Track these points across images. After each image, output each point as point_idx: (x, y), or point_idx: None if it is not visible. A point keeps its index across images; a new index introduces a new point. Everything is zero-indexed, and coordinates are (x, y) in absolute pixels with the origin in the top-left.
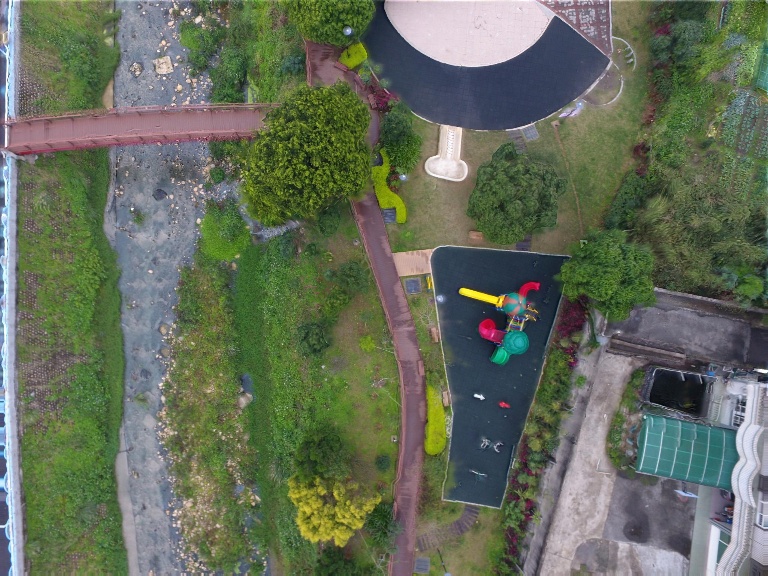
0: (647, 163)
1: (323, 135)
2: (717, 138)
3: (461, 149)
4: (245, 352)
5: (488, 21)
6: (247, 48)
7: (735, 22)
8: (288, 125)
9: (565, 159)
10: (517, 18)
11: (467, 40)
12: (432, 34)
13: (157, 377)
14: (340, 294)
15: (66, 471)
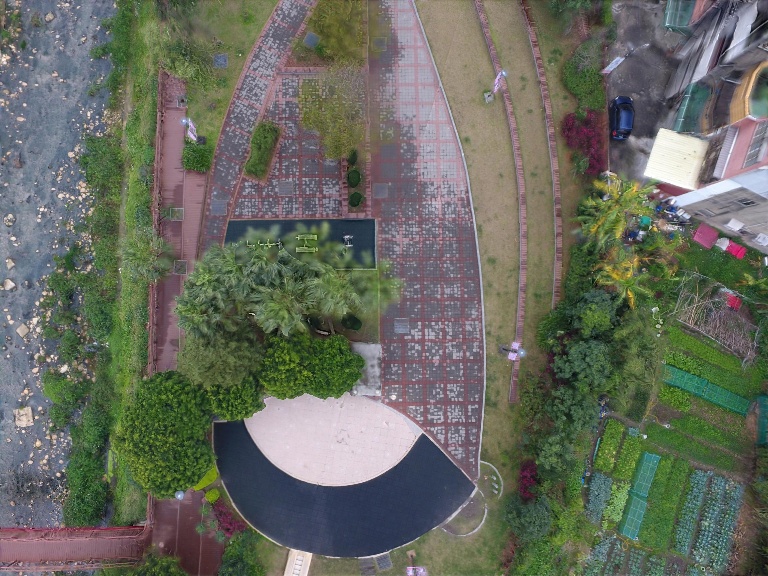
0: None
1: None
2: None
3: None
4: None
5: (351, 435)
6: (111, 408)
7: (610, 456)
8: None
9: None
10: (382, 434)
11: (327, 455)
12: (291, 447)
13: None
14: None
15: None
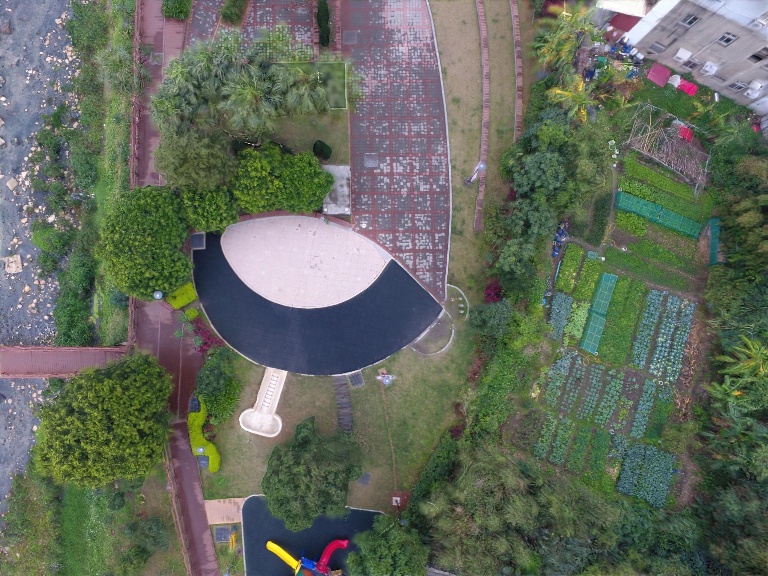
0: (465, 423)
1: (100, 435)
2: (541, 397)
3: (280, 399)
4: (69, 567)
5: (324, 261)
6: None
7: (570, 277)
8: (67, 421)
9: (386, 412)
10: (353, 259)
11: (301, 280)
12: (266, 272)
13: None
14: (136, 556)
15: None
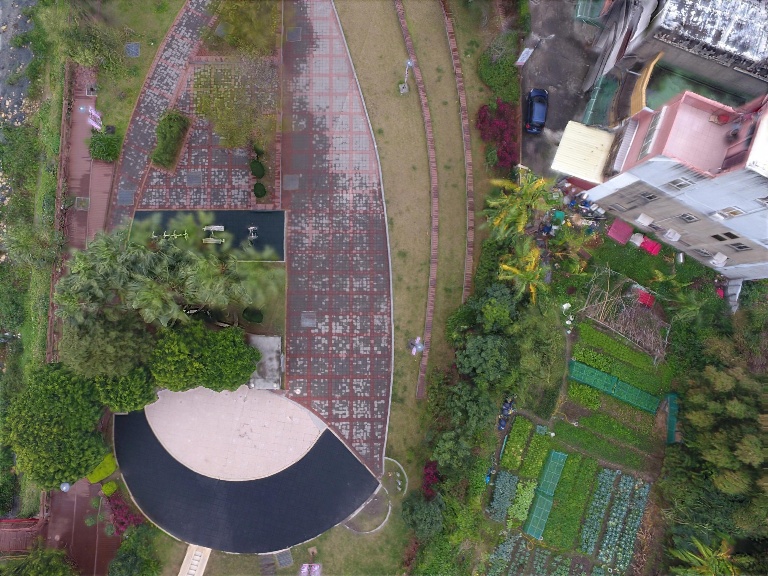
0: None
1: None
2: None
3: None
4: None
5: (254, 429)
6: None
7: (516, 454)
8: None
9: None
10: (286, 428)
11: (229, 450)
12: (192, 441)
13: None
14: None
15: None
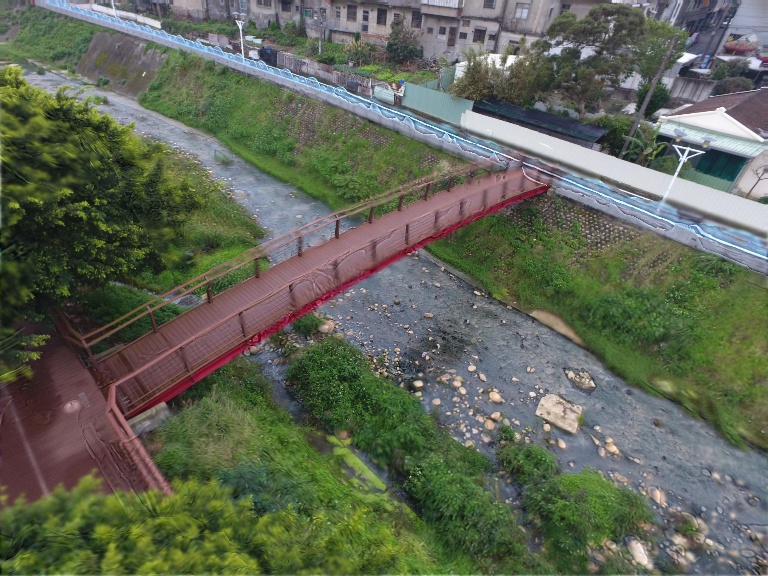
0: None
1: None
2: None
3: None
4: None
5: None
6: (476, 574)
7: None
8: None
9: None
10: None
11: None
12: None
13: (218, 171)
14: None
15: (236, 100)
